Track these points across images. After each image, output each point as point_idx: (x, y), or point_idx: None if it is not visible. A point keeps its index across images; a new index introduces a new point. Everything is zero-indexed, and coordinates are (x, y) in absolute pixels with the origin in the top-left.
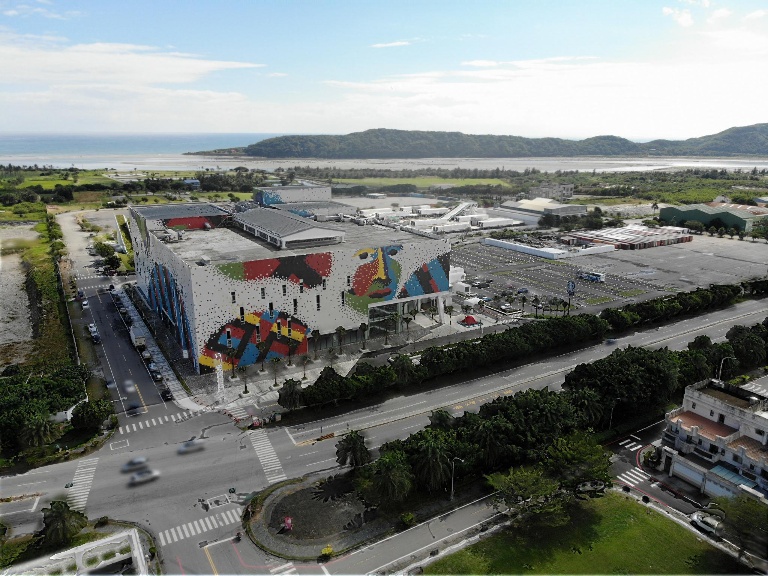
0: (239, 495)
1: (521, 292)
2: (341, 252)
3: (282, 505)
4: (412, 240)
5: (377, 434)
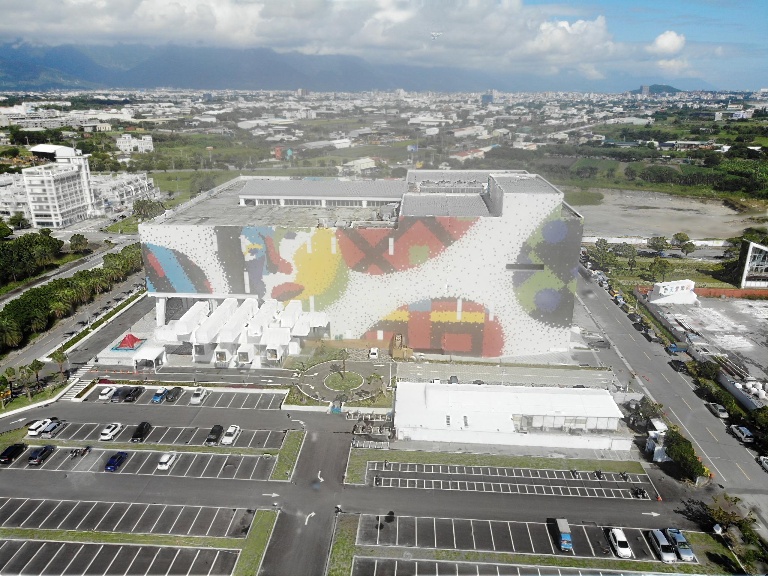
0: (122, 243)
1: (119, 453)
2: (200, 197)
3: (99, 245)
4: (190, 222)
5: (92, 265)
